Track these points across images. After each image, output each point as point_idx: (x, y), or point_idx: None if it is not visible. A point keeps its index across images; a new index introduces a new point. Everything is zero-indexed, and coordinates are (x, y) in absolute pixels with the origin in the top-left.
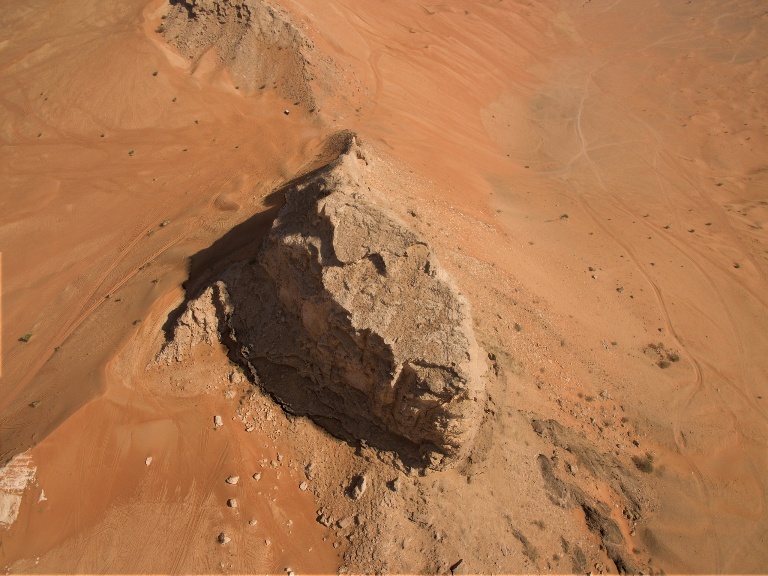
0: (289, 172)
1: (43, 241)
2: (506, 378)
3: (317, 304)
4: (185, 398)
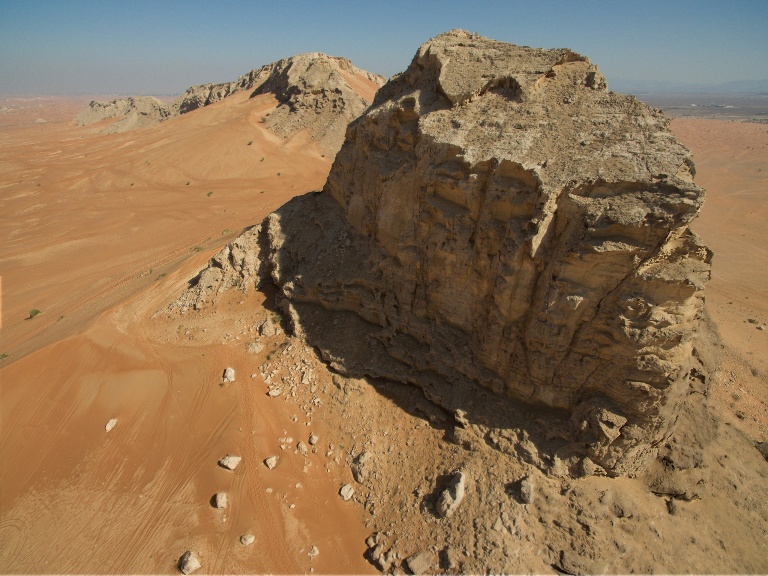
0: None
1: (97, 251)
2: (714, 325)
3: (405, 175)
4: (191, 347)
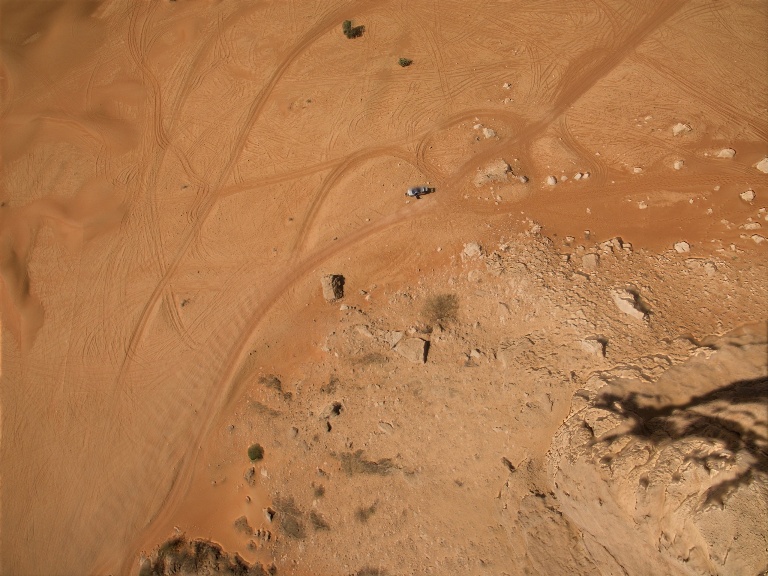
0: None
1: None
2: None
3: None
4: None
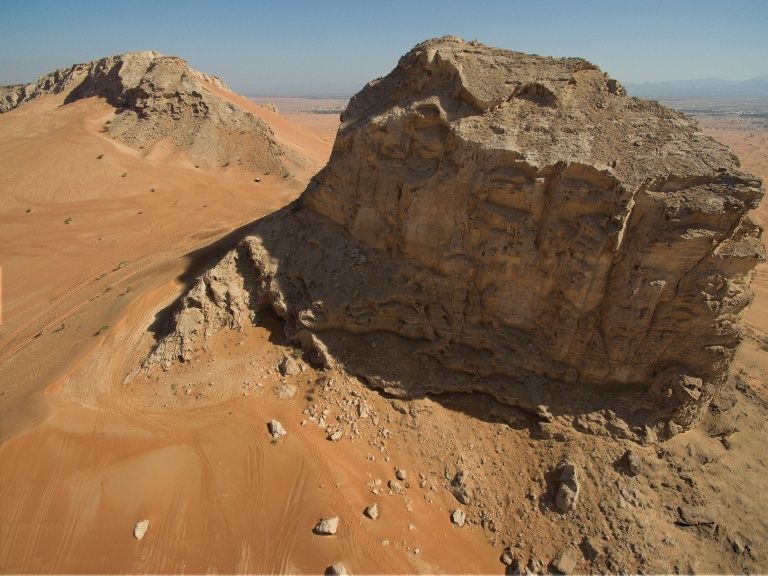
0: (279, 208)
1: None
2: None
3: (443, 184)
4: (206, 407)
